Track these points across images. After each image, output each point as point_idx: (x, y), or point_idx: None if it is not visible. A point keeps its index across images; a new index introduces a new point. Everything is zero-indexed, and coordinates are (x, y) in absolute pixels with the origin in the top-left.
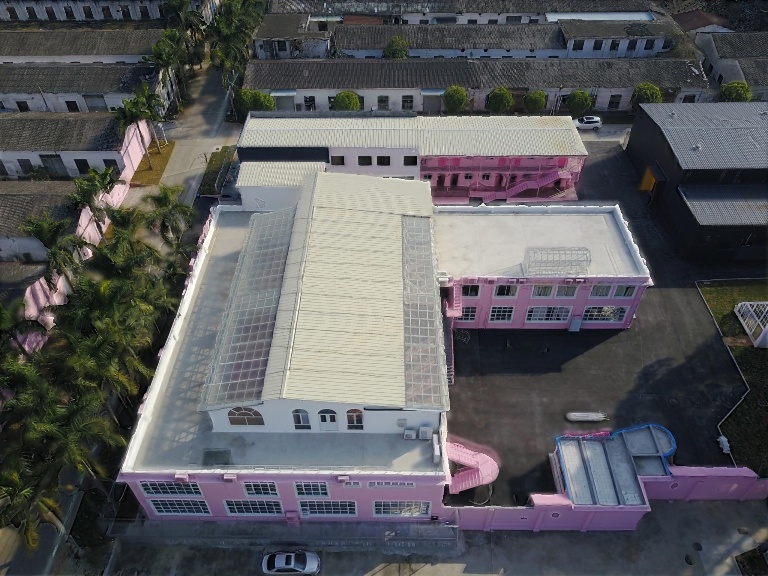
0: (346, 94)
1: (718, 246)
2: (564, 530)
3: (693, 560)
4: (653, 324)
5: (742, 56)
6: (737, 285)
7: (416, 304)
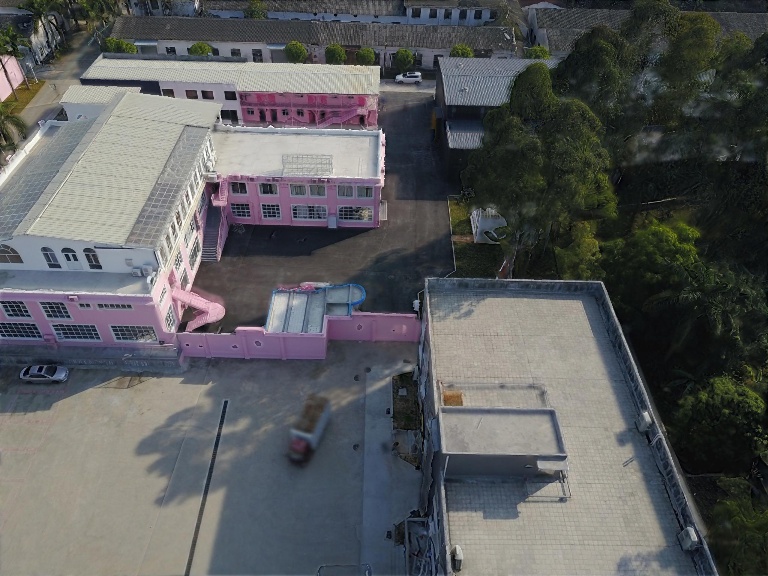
0: (199, 45)
1: None
2: (269, 358)
3: (360, 378)
4: (399, 225)
5: (558, 27)
6: None
7: (167, 184)
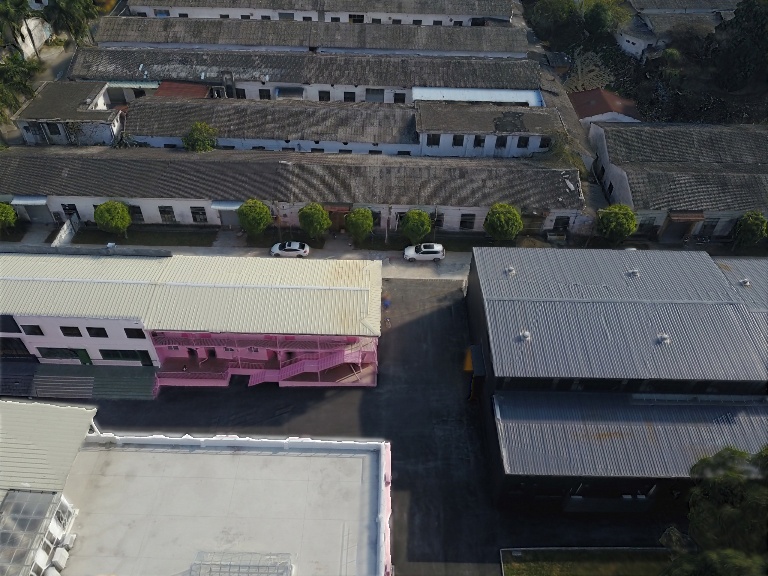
0: (107, 207)
1: (539, 493)
2: None
3: None
4: None
5: (638, 160)
6: (559, 559)
7: None
